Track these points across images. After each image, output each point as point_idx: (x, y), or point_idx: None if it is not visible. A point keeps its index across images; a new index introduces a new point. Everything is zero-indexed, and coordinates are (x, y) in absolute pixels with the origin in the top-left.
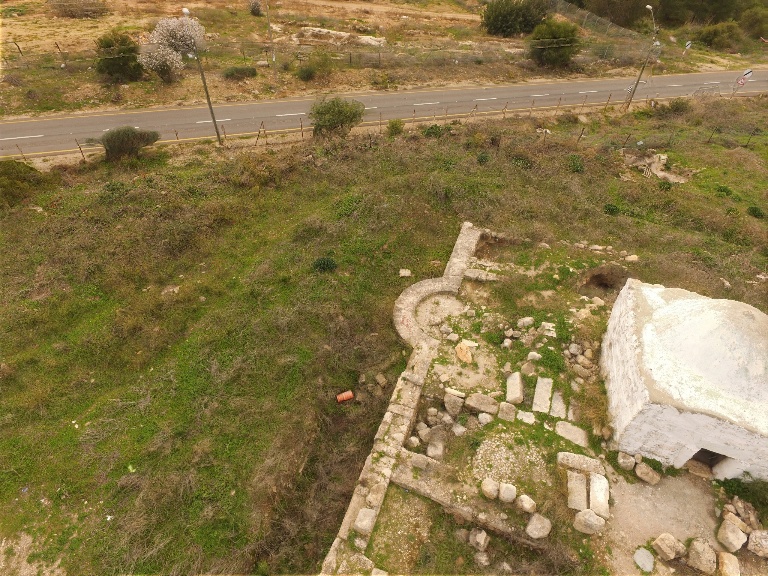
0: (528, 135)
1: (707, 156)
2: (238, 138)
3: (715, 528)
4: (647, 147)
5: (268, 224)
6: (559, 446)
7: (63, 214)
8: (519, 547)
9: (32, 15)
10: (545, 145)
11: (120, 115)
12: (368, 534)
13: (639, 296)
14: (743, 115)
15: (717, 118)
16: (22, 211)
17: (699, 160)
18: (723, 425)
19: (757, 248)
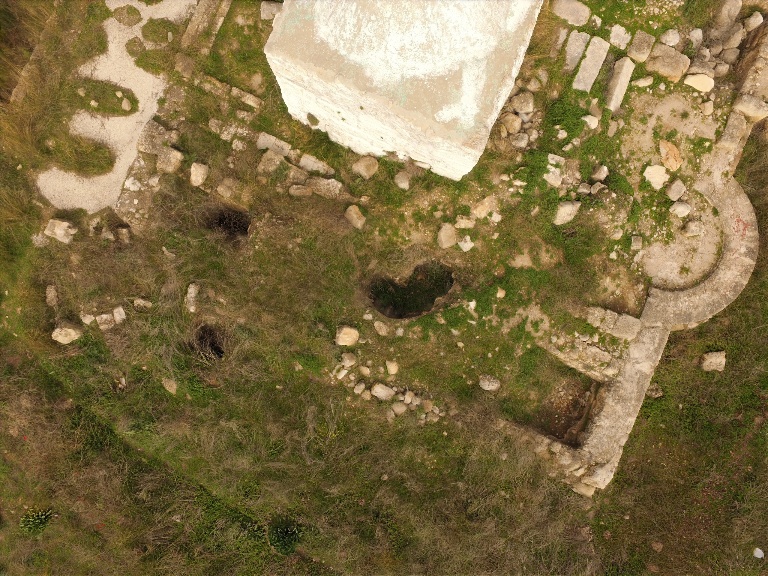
0: None
1: None
2: None
3: None
4: None
5: None
6: None
7: None
8: None
9: None
10: None
11: None
12: None
13: (488, 103)
14: None
15: None
16: None
17: None
18: None
19: (63, 405)
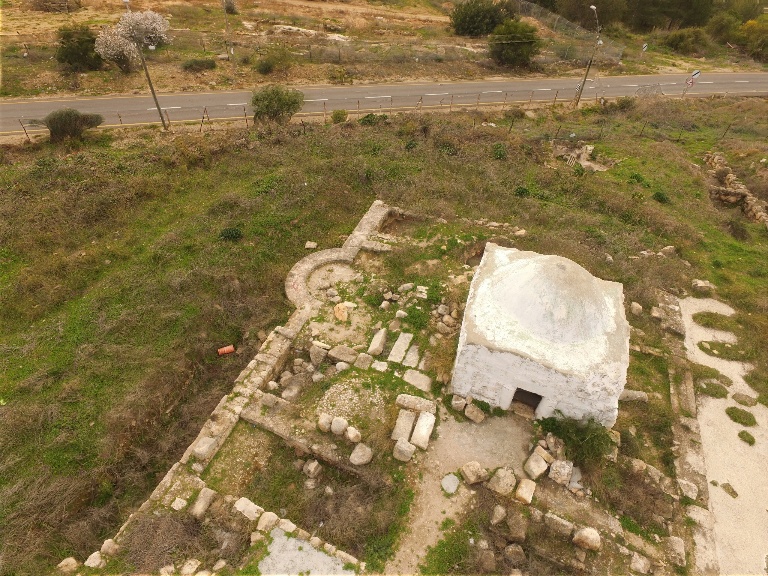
0: (462, 125)
1: (632, 147)
2: (184, 124)
3: (525, 460)
4: (579, 139)
5: (189, 199)
6: (402, 390)
7: None
8: (345, 474)
9: (9, 9)
10: (475, 134)
11: (74, 101)
12: (206, 460)
13: (490, 257)
14: (685, 113)
15: (657, 115)
16: None
17: (623, 151)
18: (526, 362)
19: (651, 229)
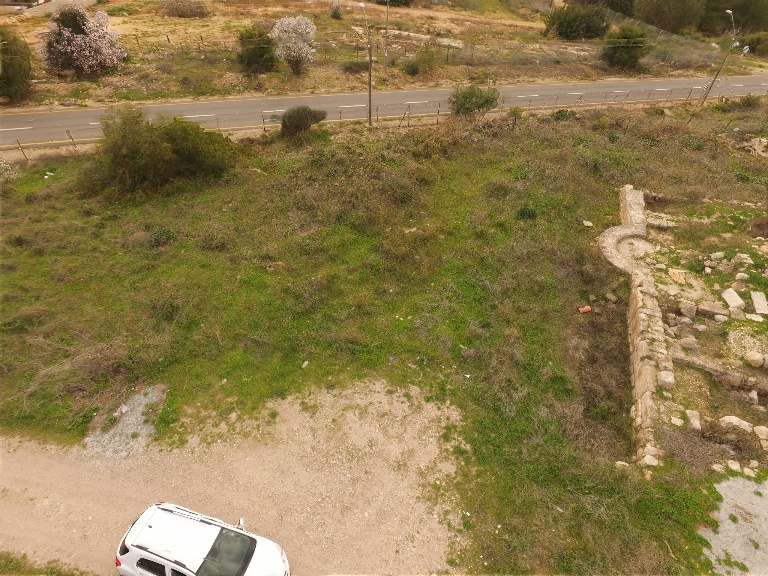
0: None
1: None
2: (382, 120)
3: None
4: (743, 133)
5: (458, 184)
6: None
7: (281, 174)
8: None
9: (139, 15)
10: (662, 128)
11: (269, 100)
12: (670, 389)
13: None
14: None
15: None
16: (245, 171)
17: None
18: None
19: None
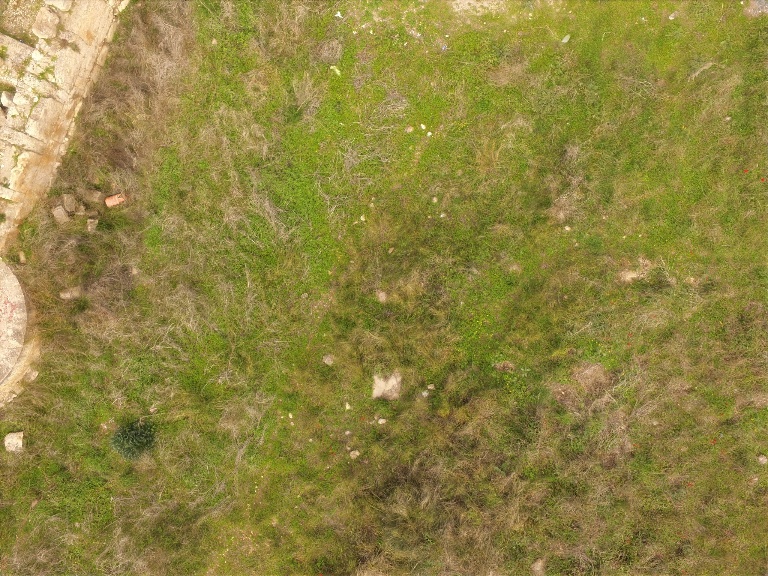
0: None
1: None
2: None
3: None
4: None
5: None
6: None
7: None
8: None
9: None
10: None
11: None
12: None
13: None
14: None
15: None
16: None
17: None
18: None
19: None
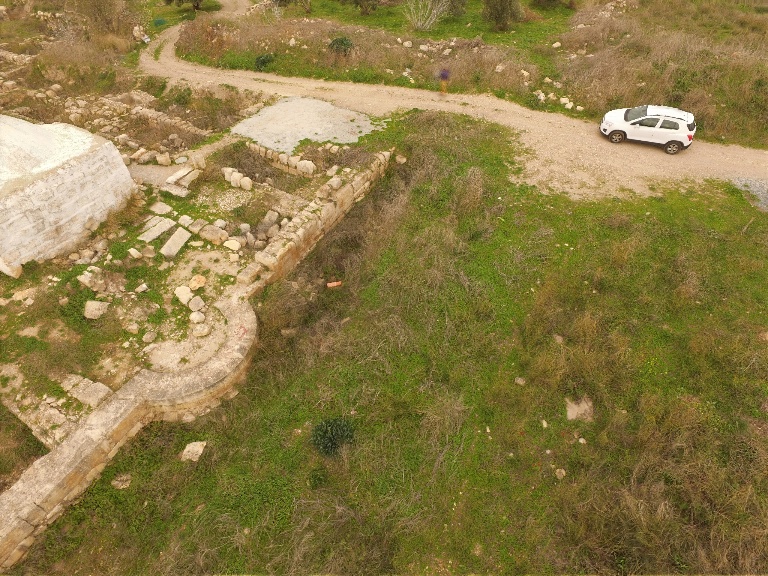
0: None
1: None
2: None
3: None
4: None
5: None
6: None
7: None
8: None
9: None
10: None
11: None
12: None
13: None
14: None
15: None
16: None
17: None
18: None
19: None
